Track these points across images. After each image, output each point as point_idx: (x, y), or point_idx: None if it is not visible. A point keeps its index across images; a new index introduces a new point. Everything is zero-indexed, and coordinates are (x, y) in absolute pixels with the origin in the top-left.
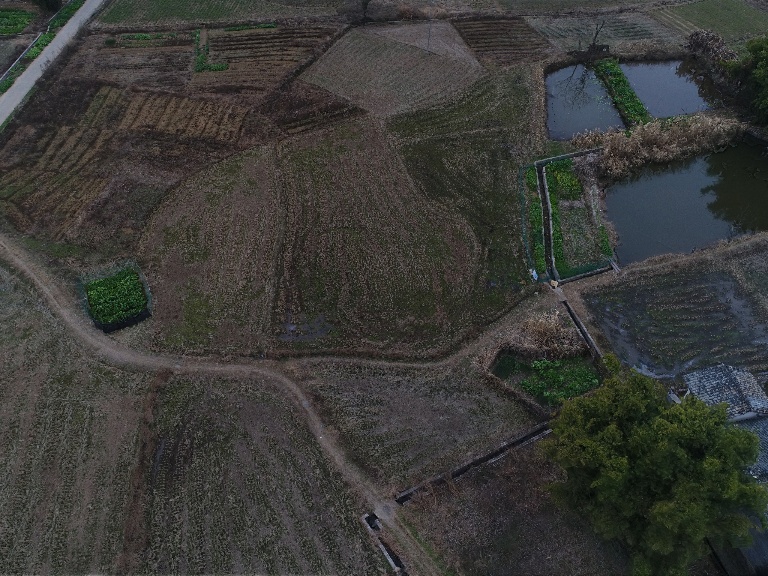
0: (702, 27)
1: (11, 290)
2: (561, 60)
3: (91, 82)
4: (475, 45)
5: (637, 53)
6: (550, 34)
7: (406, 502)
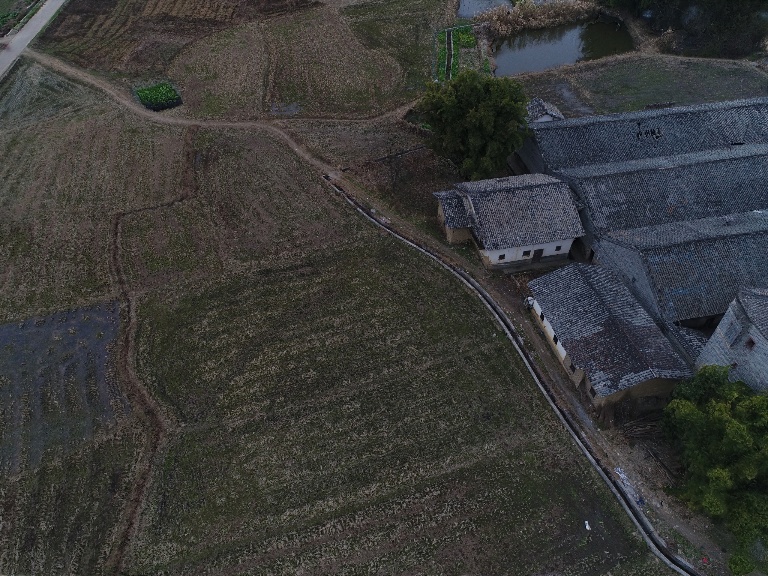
0: None
1: (87, 93)
2: None
3: None
4: None
5: None
6: None
7: (347, 171)
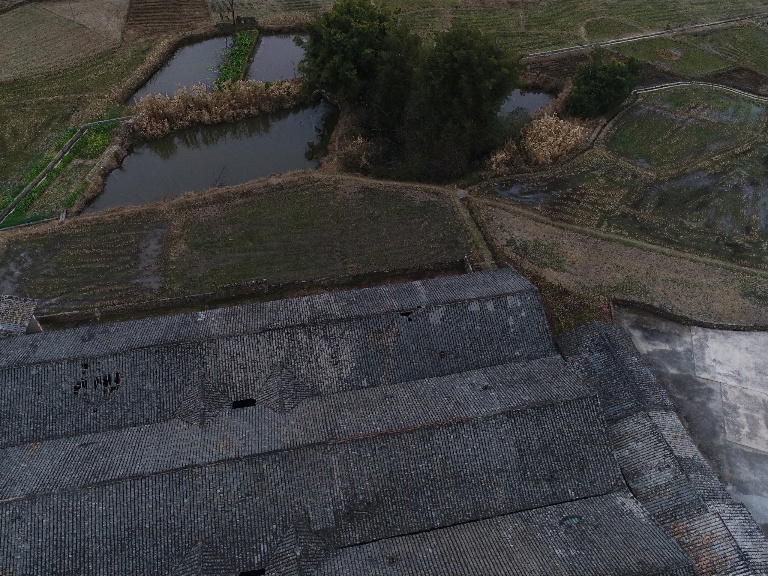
0: (377, 1)
1: None
2: (203, 32)
3: None
4: (133, 19)
5: (286, 25)
6: (219, 8)
7: None
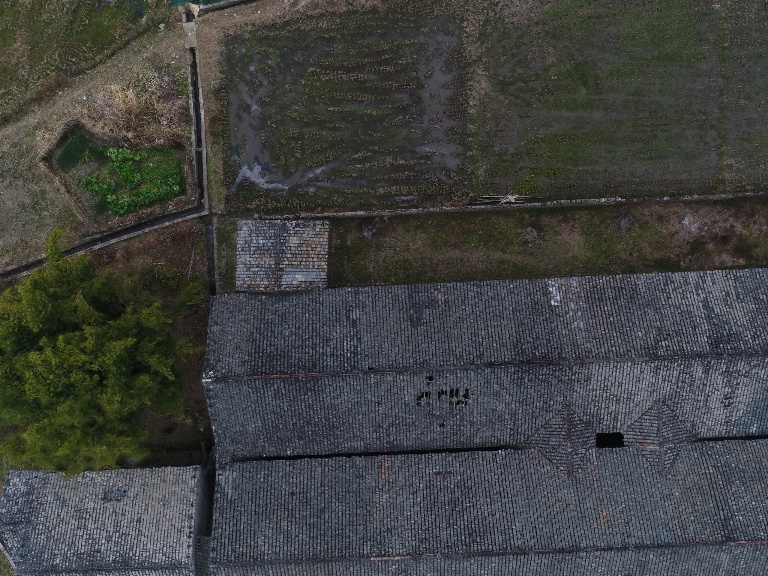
0: None
1: None
2: None
3: None
4: None
5: None
6: None
7: None
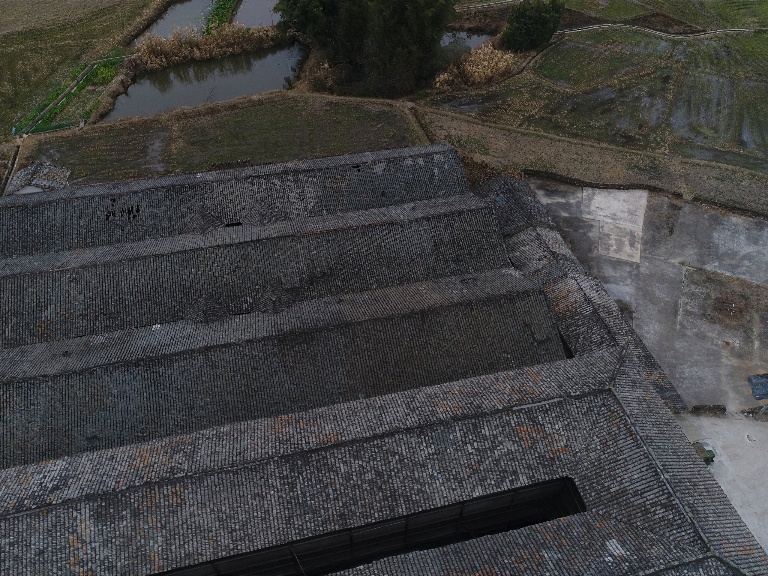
0: None
1: None
2: None
3: None
4: None
5: None
6: None
7: None
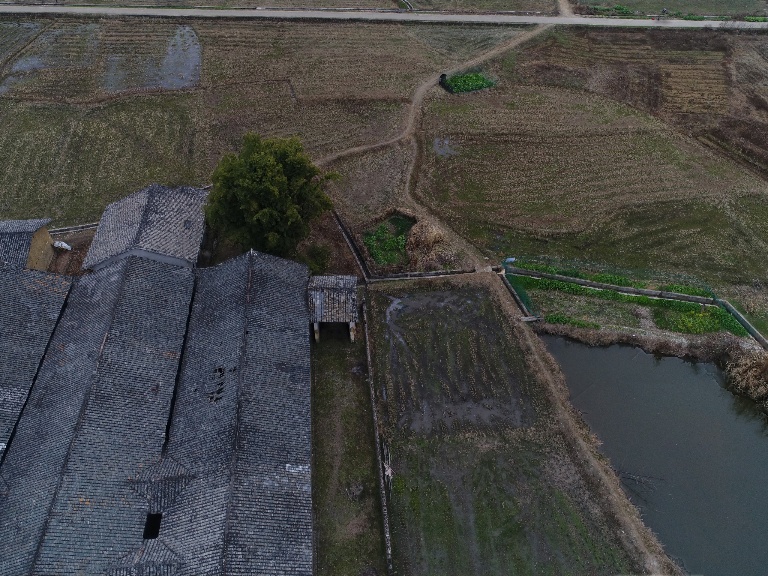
0: None
1: (471, 55)
2: None
3: (720, 44)
4: None
5: None
6: None
7: None
